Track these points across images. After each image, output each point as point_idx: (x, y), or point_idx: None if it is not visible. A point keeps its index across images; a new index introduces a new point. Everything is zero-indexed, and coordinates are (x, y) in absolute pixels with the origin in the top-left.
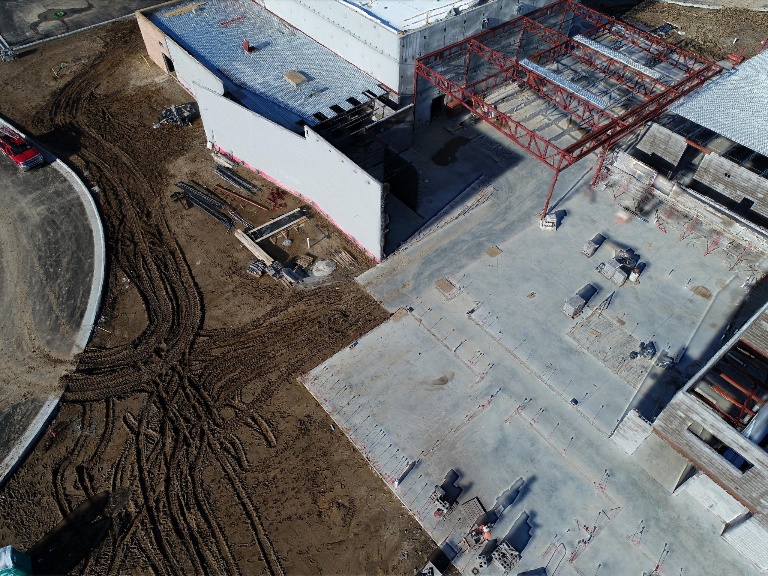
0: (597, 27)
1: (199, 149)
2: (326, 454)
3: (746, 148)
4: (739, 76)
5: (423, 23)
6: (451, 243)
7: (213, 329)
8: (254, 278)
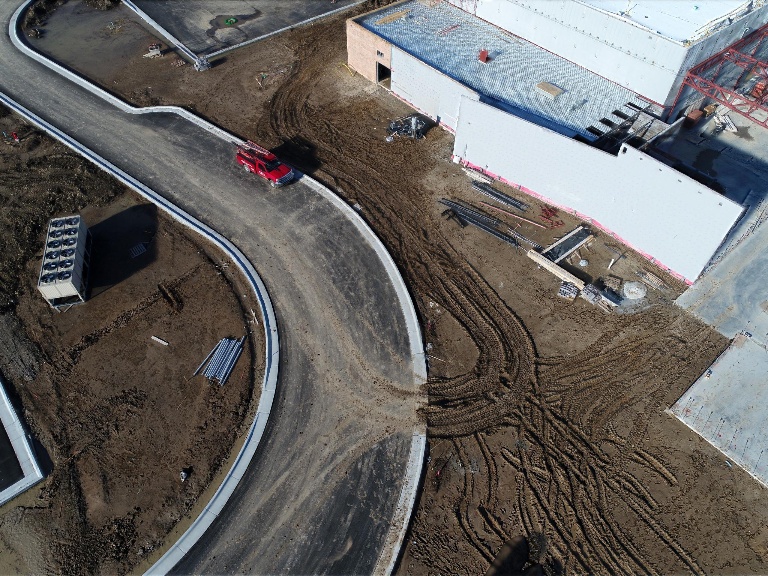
0: None
1: (445, 163)
2: (735, 493)
3: None
4: None
5: (696, 33)
6: (755, 263)
7: (550, 357)
8: (567, 301)
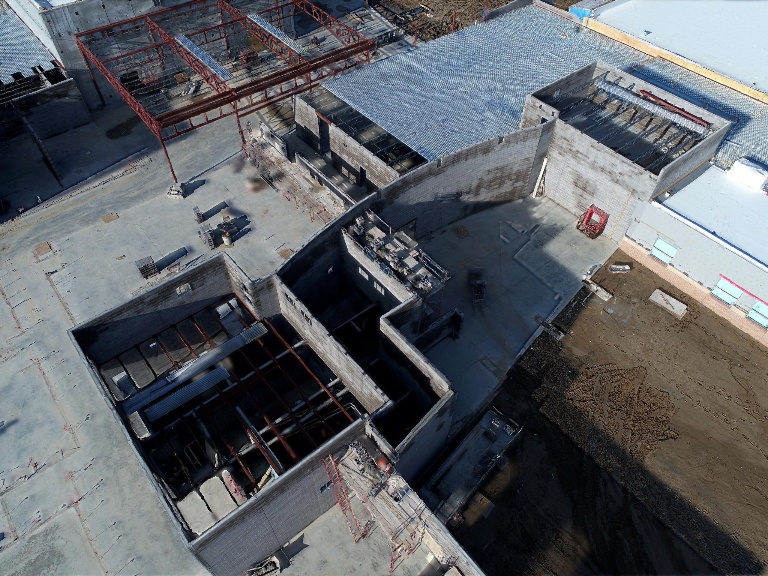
0: (280, 6)
1: None
2: None
3: (367, 119)
4: (415, 53)
5: None
6: (74, 210)
7: None
8: None
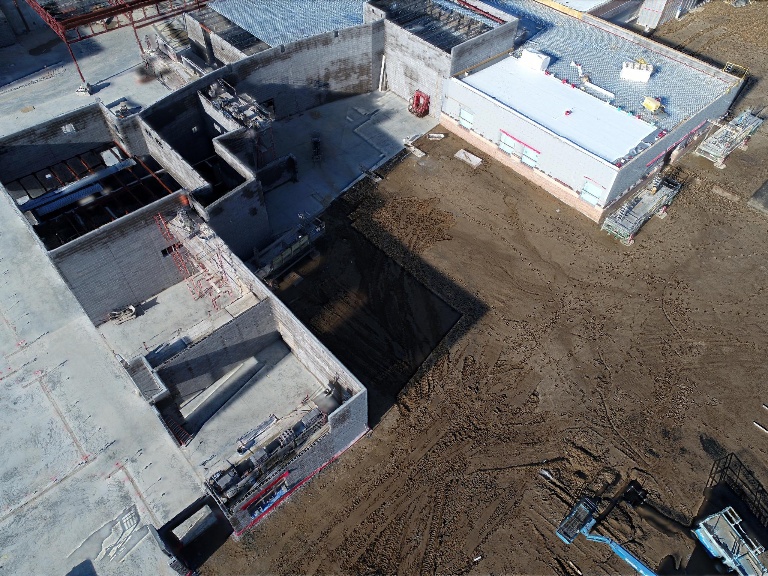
0: None
1: None
2: None
3: (241, 29)
4: None
5: None
6: None
7: None
8: None
